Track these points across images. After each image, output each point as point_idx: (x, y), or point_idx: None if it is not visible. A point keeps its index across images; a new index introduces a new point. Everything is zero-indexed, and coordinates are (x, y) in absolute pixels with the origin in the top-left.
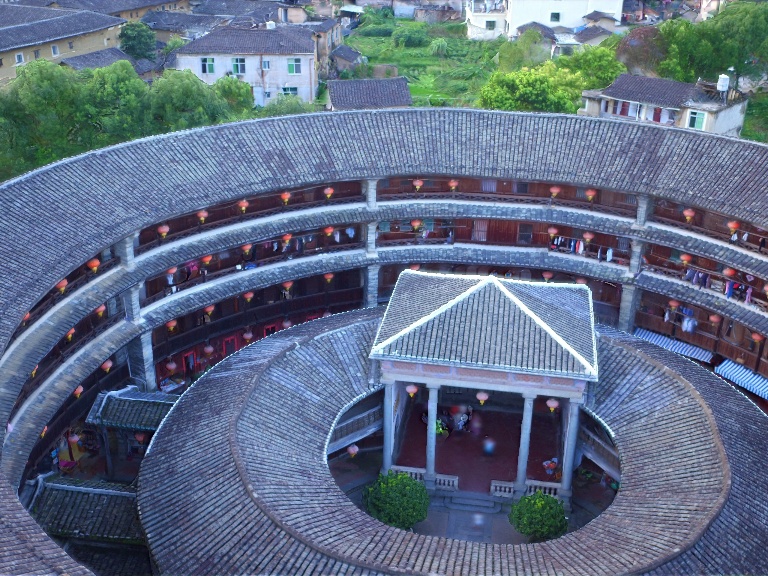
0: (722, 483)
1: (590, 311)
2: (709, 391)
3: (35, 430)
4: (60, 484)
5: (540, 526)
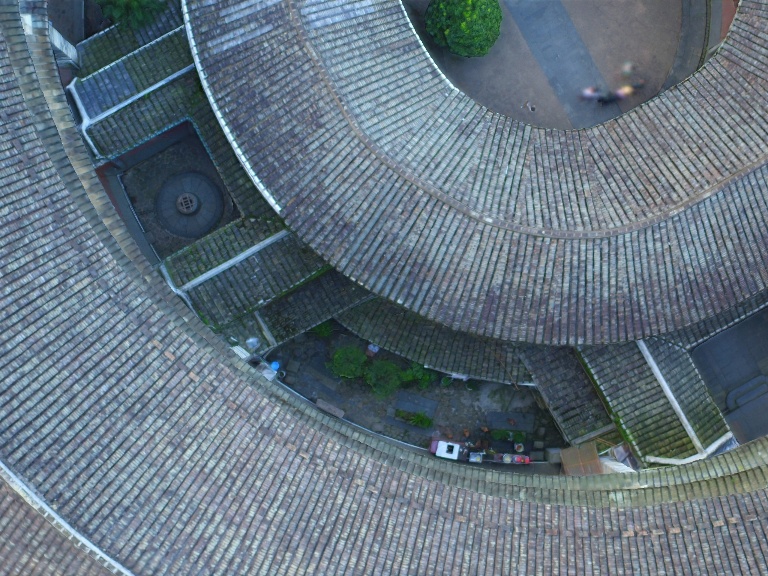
0: None
1: None
2: None
3: (156, 282)
4: (195, 277)
5: None
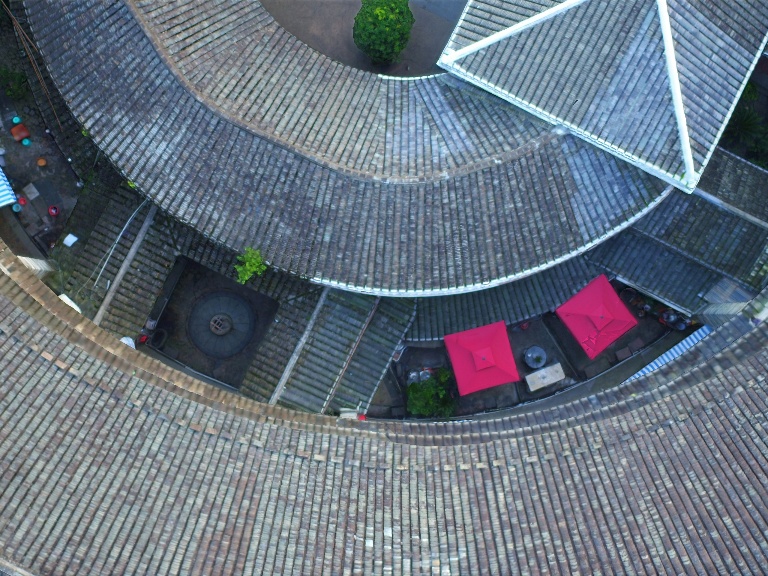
0: (208, 97)
1: (615, 144)
2: (405, 221)
3: None
4: None
5: (362, 12)
